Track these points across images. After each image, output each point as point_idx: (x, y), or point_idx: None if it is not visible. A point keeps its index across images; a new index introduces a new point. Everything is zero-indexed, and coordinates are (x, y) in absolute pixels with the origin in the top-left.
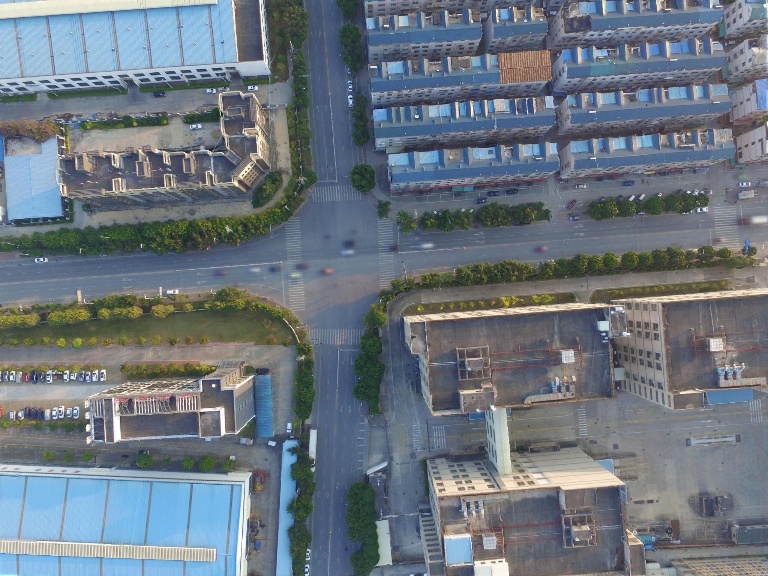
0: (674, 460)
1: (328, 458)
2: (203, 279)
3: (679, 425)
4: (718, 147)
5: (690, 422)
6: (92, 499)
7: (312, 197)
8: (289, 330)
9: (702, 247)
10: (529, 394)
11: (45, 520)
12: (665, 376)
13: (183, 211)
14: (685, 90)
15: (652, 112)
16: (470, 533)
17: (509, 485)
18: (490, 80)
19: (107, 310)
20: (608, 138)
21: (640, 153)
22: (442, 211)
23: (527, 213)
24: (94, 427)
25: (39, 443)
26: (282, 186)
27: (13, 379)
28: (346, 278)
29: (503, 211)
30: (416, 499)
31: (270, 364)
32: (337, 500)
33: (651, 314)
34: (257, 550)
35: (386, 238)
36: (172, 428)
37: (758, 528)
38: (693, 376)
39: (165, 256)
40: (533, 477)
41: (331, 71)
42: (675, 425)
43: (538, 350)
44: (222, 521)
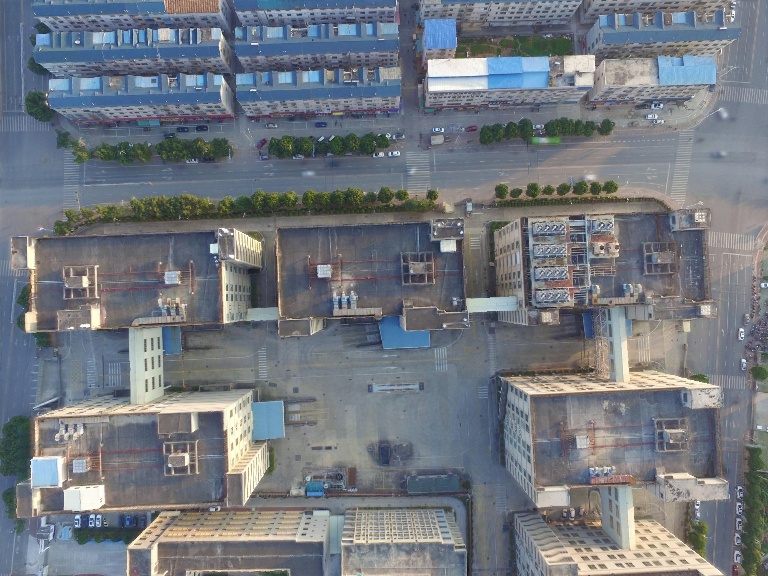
0: (355, 406)
1: None
2: None
3: (362, 371)
4: (382, 84)
5: (373, 368)
6: None
7: None
8: None
9: (381, 188)
10: (138, 316)
11: None
12: (279, 303)
13: None
14: (355, 27)
15: (318, 47)
16: (67, 457)
17: (118, 410)
18: (156, 9)
19: None
20: (272, 71)
21: (303, 87)
22: (119, 143)
23: (199, 146)
24: None
25: None
26: None
27: None
28: (28, 209)
29: (178, 144)
30: None
31: None
32: None
33: None
34: None
35: (72, 170)
36: None
37: (430, 477)
38: (309, 304)
39: None
40: (155, 406)
41: (25, 2)
42: (358, 370)
43: (150, 272)
44: None
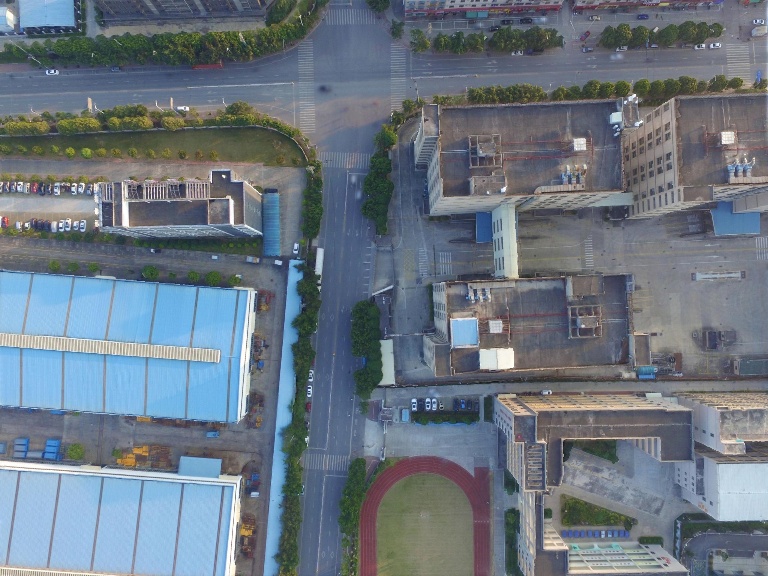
0: (679, 294)
1: (334, 281)
2: (214, 98)
3: (685, 259)
4: None
5: (696, 257)
6: (97, 298)
7: (326, 20)
8: (299, 152)
9: (714, 77)
10: (539, 185)
11: (50, 316)
12: (675, 172)
13: (196, 29)
14: None
15: None
16: None
17: None
18: None
19: (117, 118)
20: None
21: None
22: (456, 32)
23: (541, 33)
24: (102, 215)
25: (45, 255)
26: (296, 6)
27: (21, 189)
28: (357, 102)
29: (517, 33)
30: (421, 324)
31: (279, 185)
32: (342, 323)
33: (663, 116)
34: (260, 369)
35: (399, 63)
36: (180, 219)
37: (760, 360)
38: (703, 173)
39: (177, 73)
40: None
41: None
42: (681, 259)
43: (550, 142)
44: (227, 324)
